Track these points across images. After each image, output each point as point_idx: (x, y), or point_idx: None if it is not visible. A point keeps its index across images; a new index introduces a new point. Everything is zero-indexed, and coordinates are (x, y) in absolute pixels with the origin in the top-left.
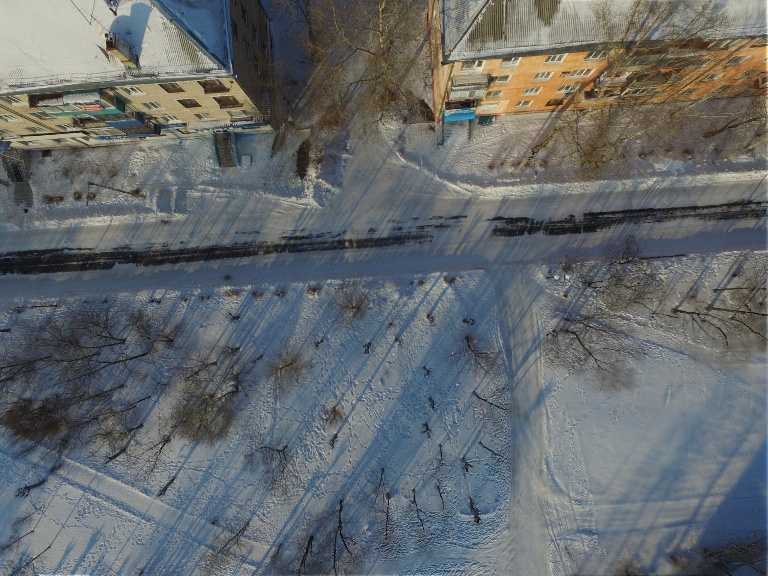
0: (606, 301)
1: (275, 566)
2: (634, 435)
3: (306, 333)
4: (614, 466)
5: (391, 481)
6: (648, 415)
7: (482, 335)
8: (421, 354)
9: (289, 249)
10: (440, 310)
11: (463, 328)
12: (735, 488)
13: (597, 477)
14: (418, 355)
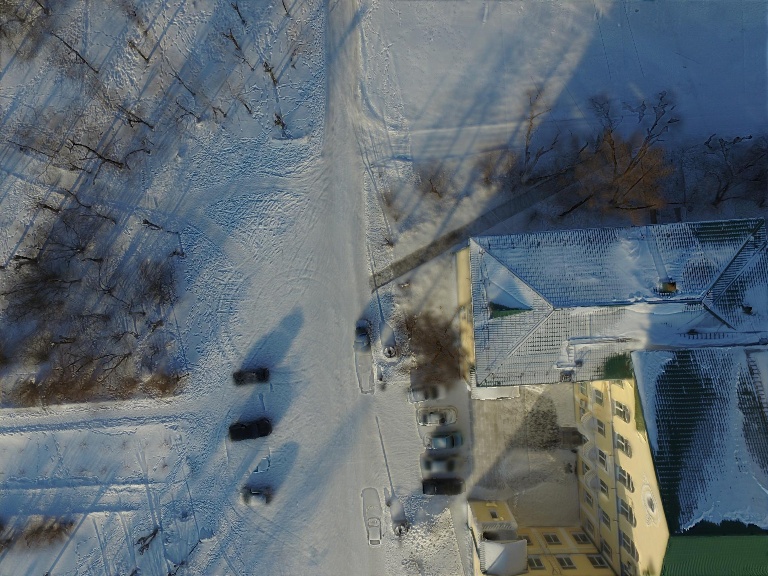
0: None
1: (84, 194)
2: (449, 55)
3: None
4: (429, 89)
5: (202, 106)
6: (464, 35)
7: None
8: None
9: None
10: None
11: None
12: (553, 110)
13: (412, 101)
14: None
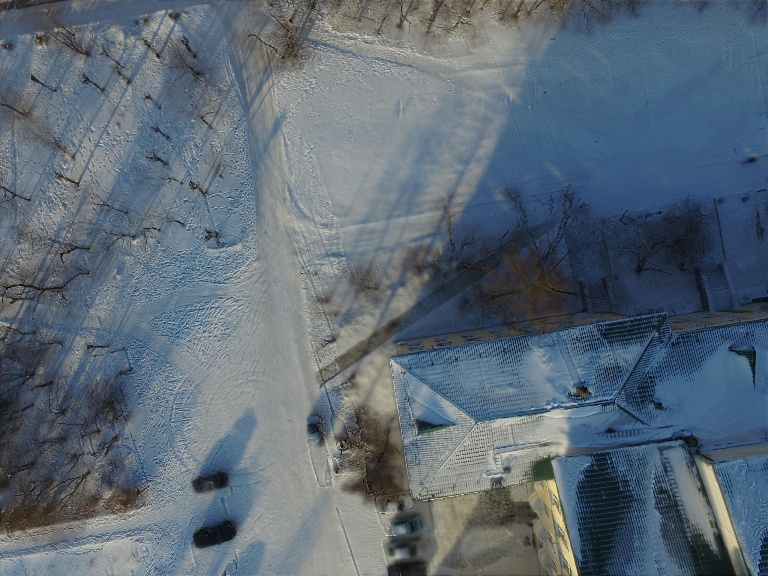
0: (332, 23)
1: (28, 321)
2: (371, 152)
3: (39, 85)
4: (355, 185)
5: (136, 223)
6: (383, 131)
7: (213, 69)
8: (155, 94)
9: (17, 5)
10: (170, 49)
11: (194, 64)
12: (475, 195)
13: (339, 199)
14: (152, 96)
